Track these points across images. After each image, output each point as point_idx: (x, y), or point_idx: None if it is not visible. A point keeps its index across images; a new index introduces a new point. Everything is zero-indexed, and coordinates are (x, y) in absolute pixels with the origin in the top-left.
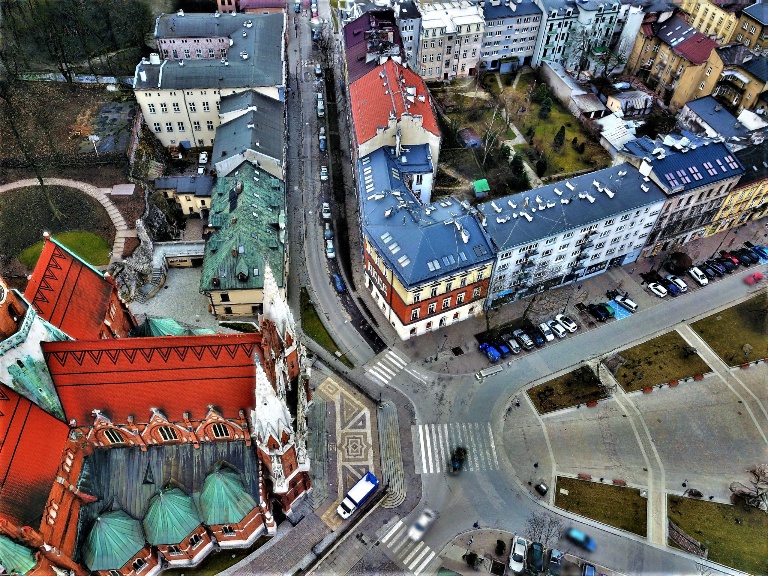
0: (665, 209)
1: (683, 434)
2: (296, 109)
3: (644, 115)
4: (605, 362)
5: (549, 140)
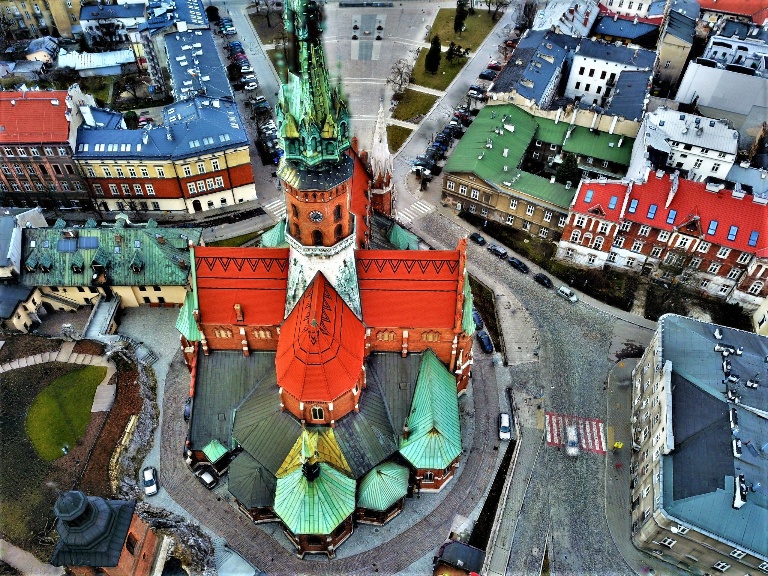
0: None
1: (356, 105)
2: None
3: None
4: None
5: None
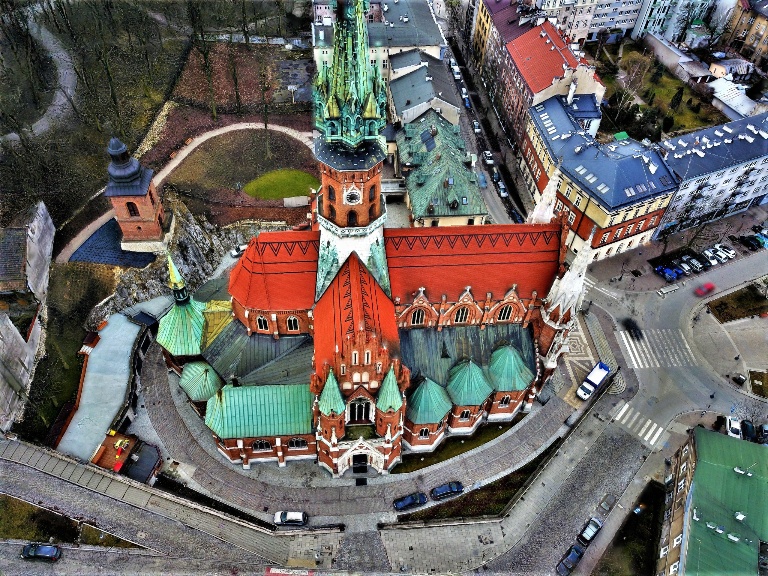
0: None
1: None
2: None
3: (744, 81)
4: (765, 282)
5: (665, 101)
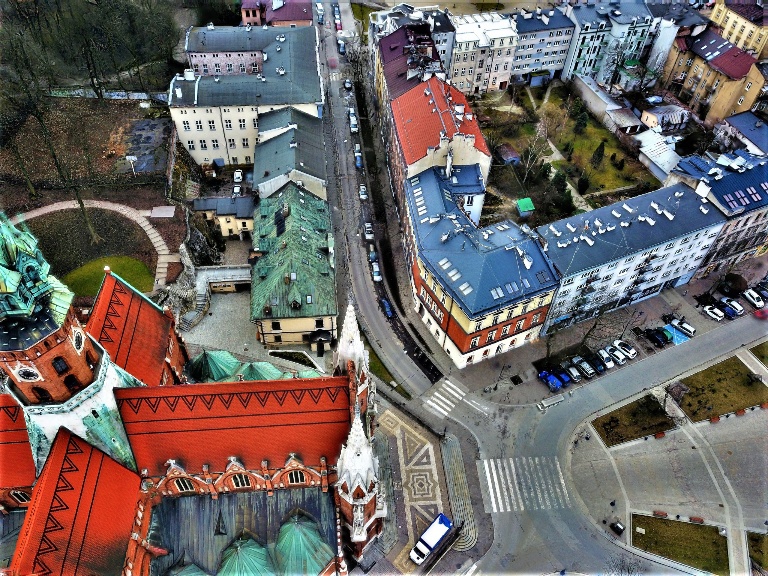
0: (723, 231)
1: (755, 467)
2: (328, 124)
3: (680, 130)
4: None
5: (587, 156)
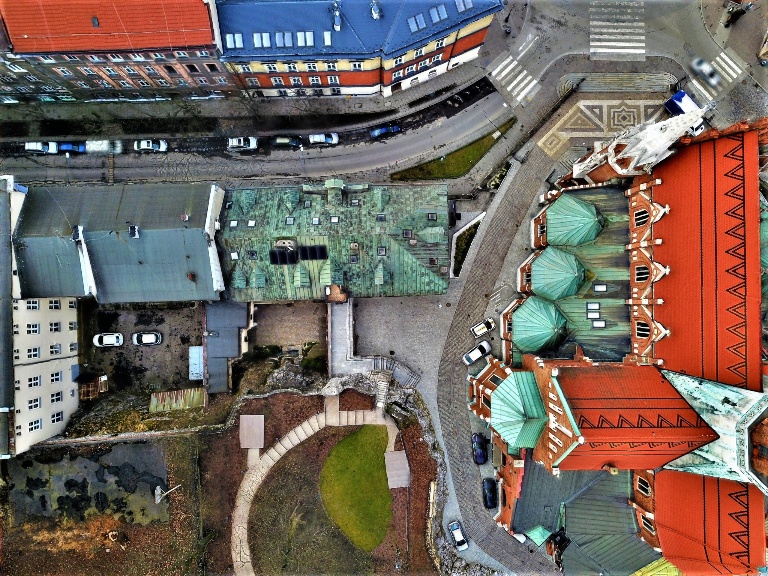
0: None
1: None
2: None
3: None
4: None
5: None
